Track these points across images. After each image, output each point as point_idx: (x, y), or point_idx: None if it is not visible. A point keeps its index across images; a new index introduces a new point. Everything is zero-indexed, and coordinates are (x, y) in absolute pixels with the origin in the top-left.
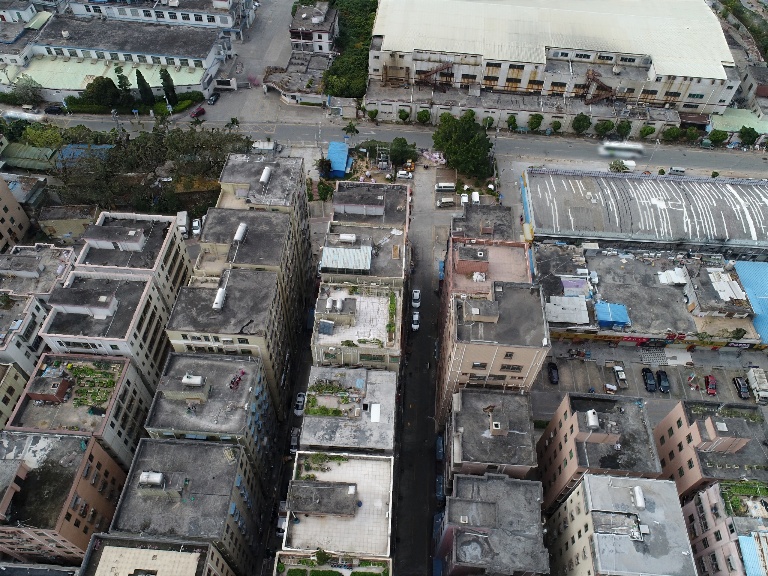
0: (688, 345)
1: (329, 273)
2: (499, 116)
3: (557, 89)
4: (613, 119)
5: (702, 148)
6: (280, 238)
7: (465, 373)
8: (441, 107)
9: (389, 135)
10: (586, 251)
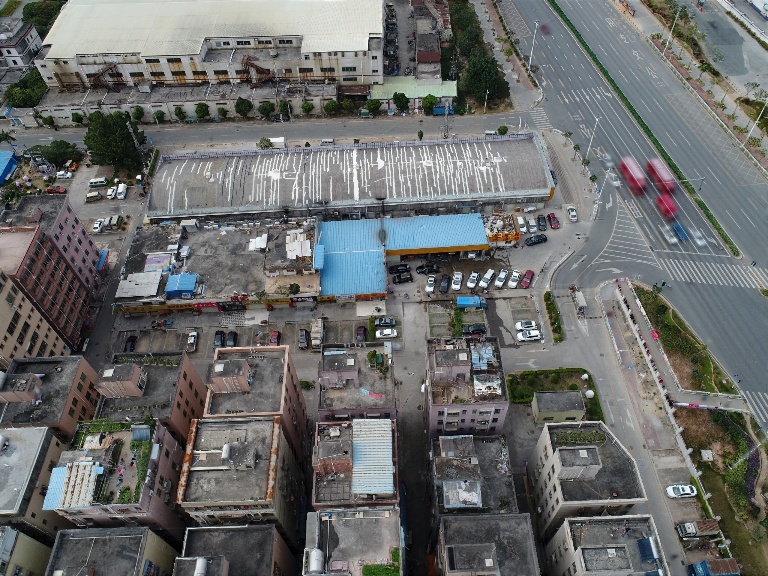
0: (265, 305)
1: None
2: (167, 109)
3: (222, 77)
4: (272, 100)
5: (363, 118)
6: None
7: None
8: (110, 107)
9: (65, 139)
10: (185, 228)
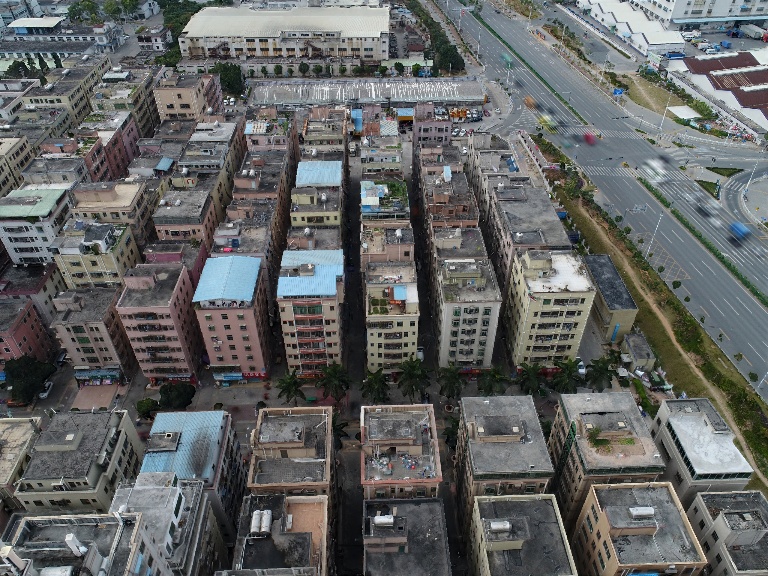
0: None
1: (107, 83)
2: (257, 68)
3: (291, 53)
4: (322, 64)
5: (376, 77)
6: (86, 74)
7: (167, 114)
8: None
9: None
10: None
